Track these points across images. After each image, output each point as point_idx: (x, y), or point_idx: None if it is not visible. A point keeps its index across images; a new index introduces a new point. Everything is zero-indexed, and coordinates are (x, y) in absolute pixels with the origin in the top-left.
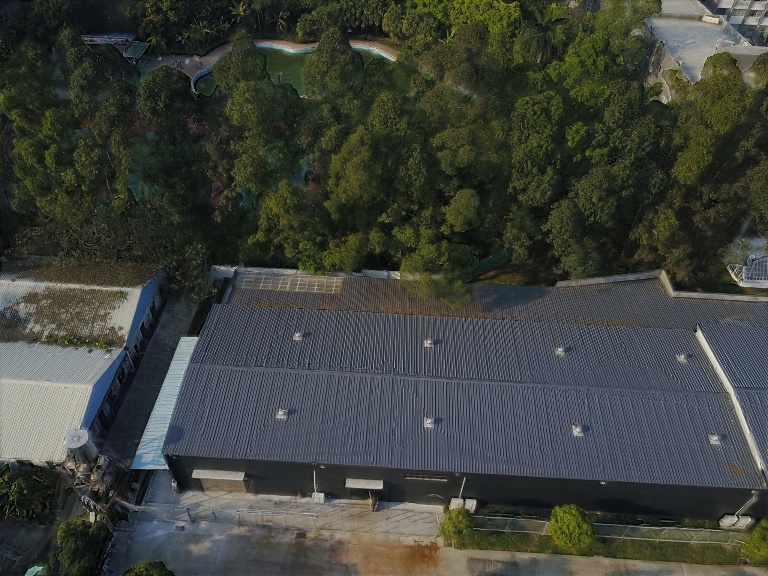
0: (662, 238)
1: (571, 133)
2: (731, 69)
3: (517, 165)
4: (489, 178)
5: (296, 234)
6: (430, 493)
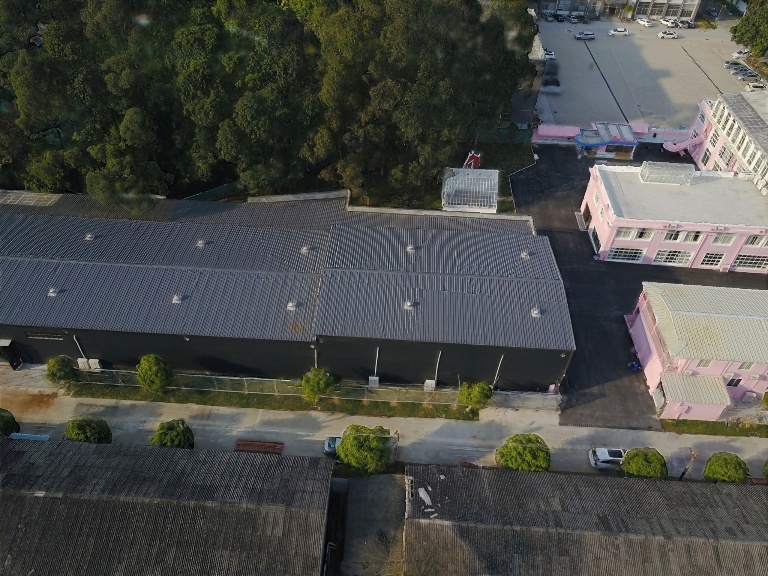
0: (322, 155)
1: (225, 60)
2: (369, 6)
3: (182, 88)
4: (161, 100)
5: (2, 151)
6: (60, 354)
